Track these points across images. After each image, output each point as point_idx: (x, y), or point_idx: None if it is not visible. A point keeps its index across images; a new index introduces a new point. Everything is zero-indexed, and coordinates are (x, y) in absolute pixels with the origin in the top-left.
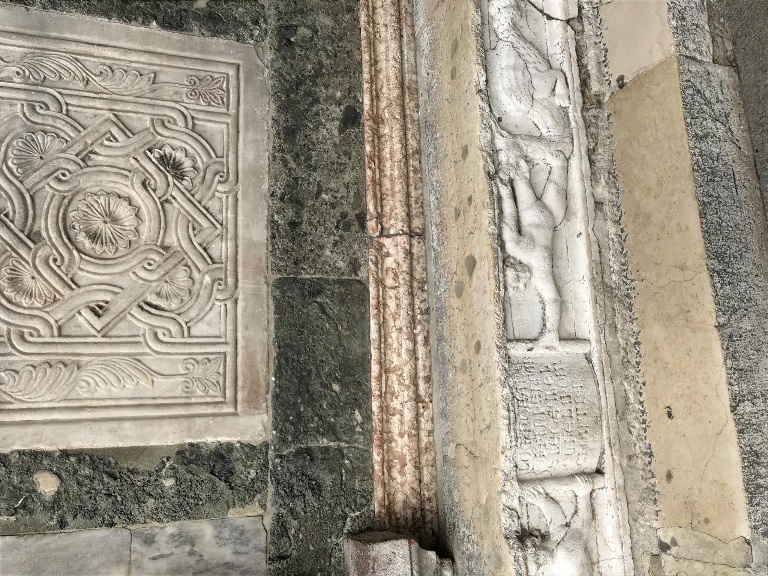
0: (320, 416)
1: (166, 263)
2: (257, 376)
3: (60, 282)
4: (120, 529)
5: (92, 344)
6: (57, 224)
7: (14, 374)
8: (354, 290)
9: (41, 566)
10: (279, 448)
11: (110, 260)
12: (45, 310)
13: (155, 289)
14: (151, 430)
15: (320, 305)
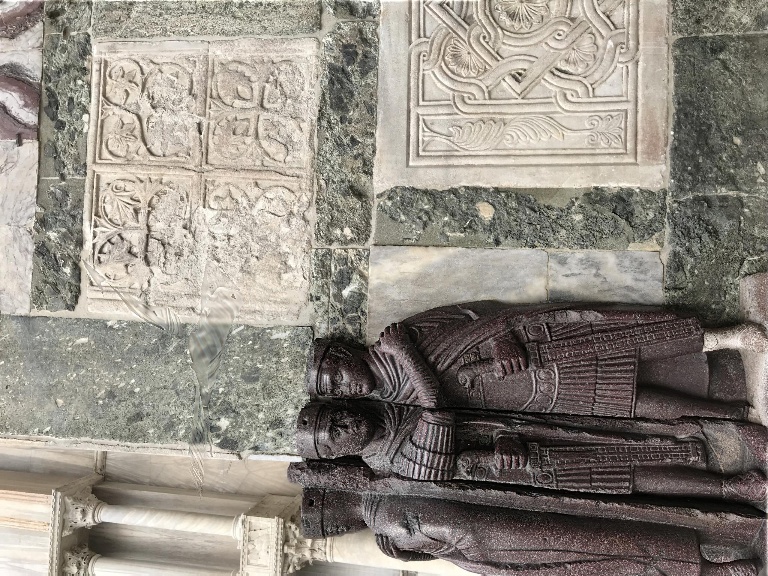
0: (719, 167)
1: (574, 32)
2: (656, 131)
3: (489, 55)
4: (539, 251)
5: (514, 105)
6: (485, 7)
7: (459, 129)
8: (761, 44)
9: (483, 271)
10: (677, 195)
11: (527, 34)
12: (479, 78)
13: (564, 56)
14: (562, 175)
15: (723, 62)
